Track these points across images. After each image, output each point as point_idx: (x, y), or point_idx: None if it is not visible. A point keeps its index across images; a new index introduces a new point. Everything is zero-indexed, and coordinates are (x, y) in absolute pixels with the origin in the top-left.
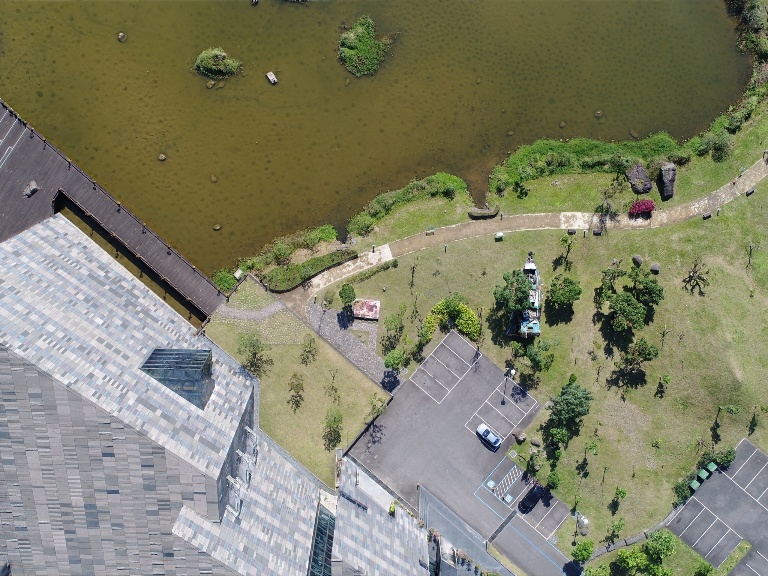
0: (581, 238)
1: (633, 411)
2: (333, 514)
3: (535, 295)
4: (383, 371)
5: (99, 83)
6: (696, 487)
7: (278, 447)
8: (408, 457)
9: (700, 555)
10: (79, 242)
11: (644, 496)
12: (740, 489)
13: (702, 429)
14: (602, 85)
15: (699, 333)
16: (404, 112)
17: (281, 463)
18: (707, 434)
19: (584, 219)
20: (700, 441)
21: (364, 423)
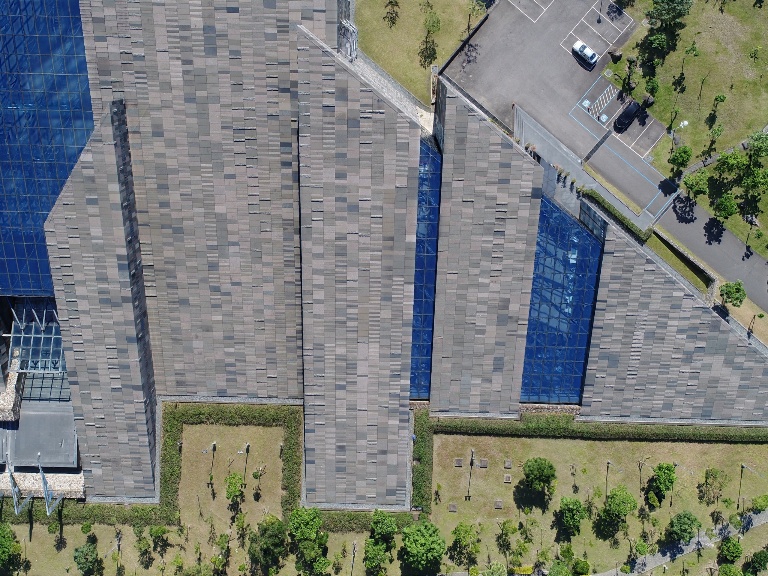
0: None
1: (731, 23)
2: (429, 131)
3: None
4: None
5: None
6: None
7: (374, 64)
8: (503, 76)
9: None
10: None
11: (742, 107)
12: None
13: None
14: None
15: None
16: None
17: None
18: None
19: None
20: None
21: (460, 40)
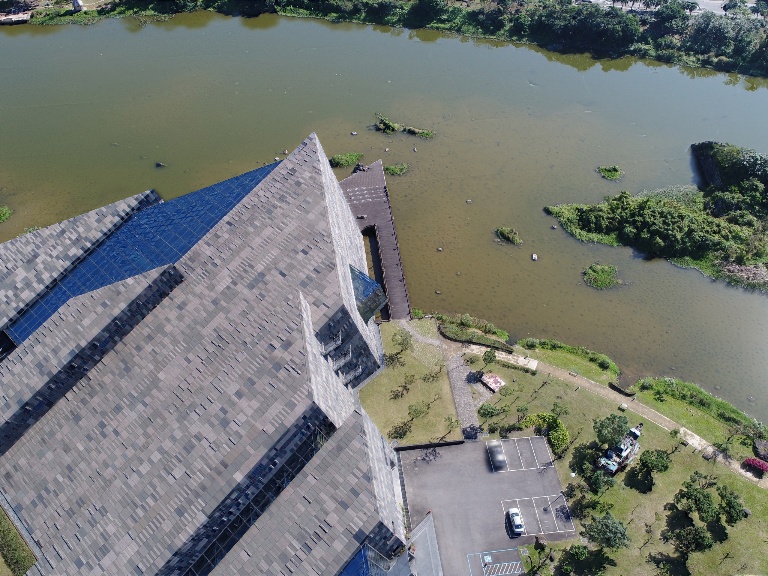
0: (690, 451)
1: None
2: None
3: (627, 446)
4: (471, 423)
5: (439, 208)
6: None
7: None
8: (440, 487)
9: None
10: (361, 244)
11: None
12: None
13: None
14: (764, 386)
15: (763, 574)
16: (604, 316)
17: None
18: None
19: (700, 442)
20: None
21: (429, 440)
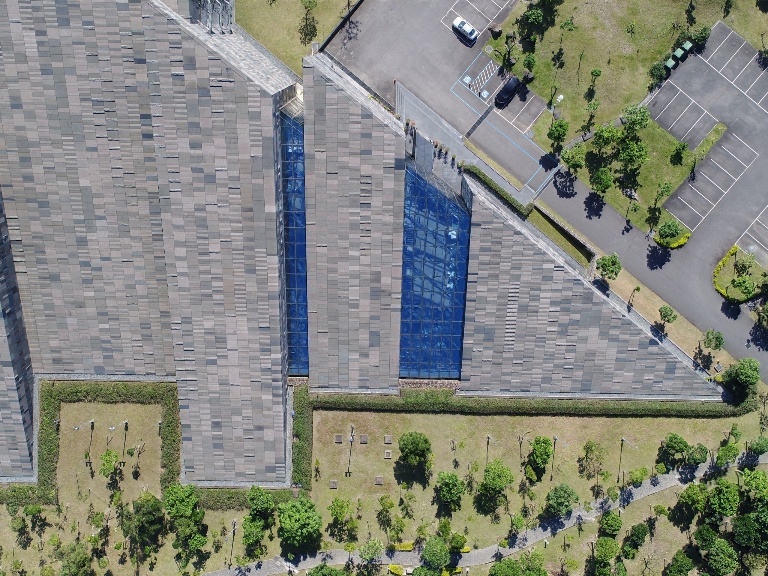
0: None
1: None
2: None
3: None
4: None
5: None
6: (671, 65)
7: (254, 41)
8: (384, 53)
9: (676, 138)
10: None
11: (620, 82)
12: (715, 71)
13: (677, 12)
14: None
15: None
16: None
17: (257, 51)
18: (682, 17)
19: None
20: (675, 23)
21: (340, 17)
